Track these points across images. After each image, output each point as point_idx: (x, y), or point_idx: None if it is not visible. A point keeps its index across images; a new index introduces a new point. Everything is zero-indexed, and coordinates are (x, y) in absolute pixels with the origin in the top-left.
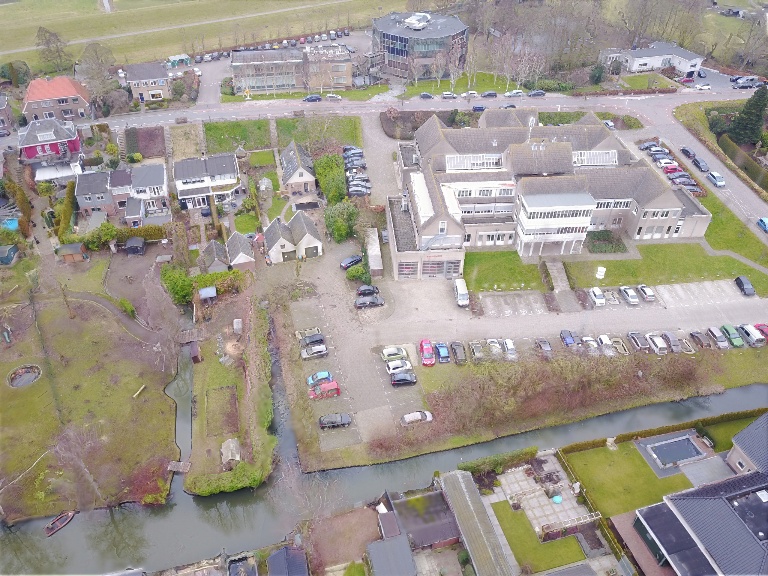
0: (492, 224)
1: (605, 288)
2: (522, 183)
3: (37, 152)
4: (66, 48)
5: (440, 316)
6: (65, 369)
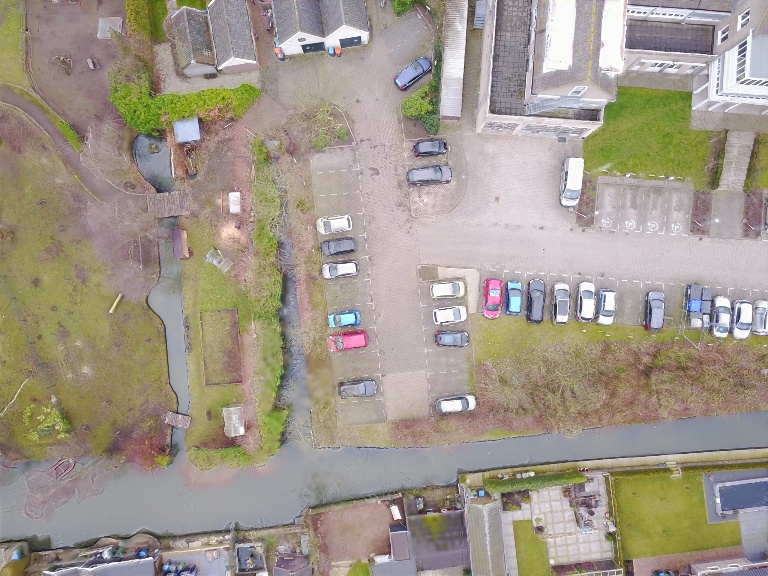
0: (671, 53)
1: None
2: (766, 9)
3: None
4: None
5: (528, 218)
6: (13, 246)
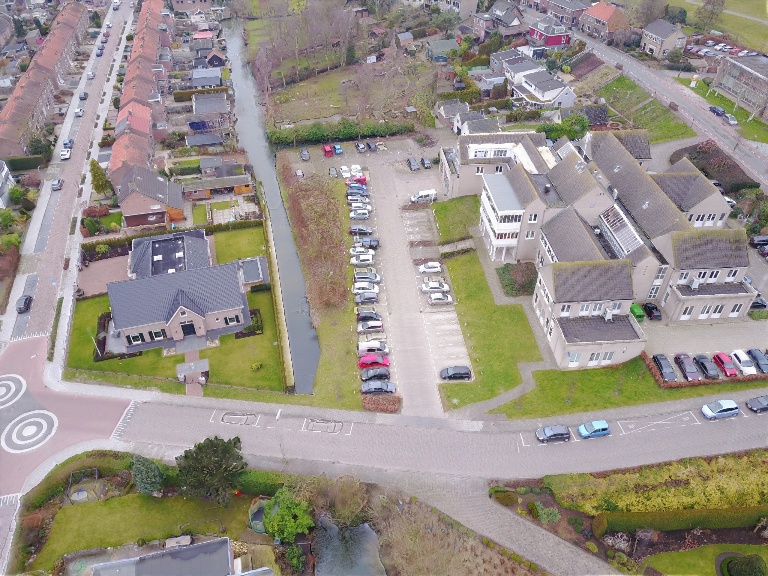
0: None
1: (448, 278)
2: None
3: (534, 34)
4: (744, 20)
5: (401, 192)
6: (354, 90)
